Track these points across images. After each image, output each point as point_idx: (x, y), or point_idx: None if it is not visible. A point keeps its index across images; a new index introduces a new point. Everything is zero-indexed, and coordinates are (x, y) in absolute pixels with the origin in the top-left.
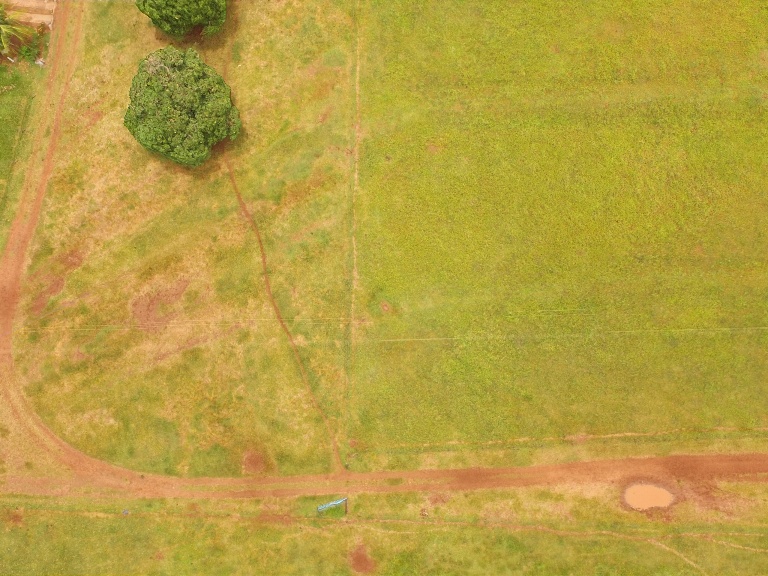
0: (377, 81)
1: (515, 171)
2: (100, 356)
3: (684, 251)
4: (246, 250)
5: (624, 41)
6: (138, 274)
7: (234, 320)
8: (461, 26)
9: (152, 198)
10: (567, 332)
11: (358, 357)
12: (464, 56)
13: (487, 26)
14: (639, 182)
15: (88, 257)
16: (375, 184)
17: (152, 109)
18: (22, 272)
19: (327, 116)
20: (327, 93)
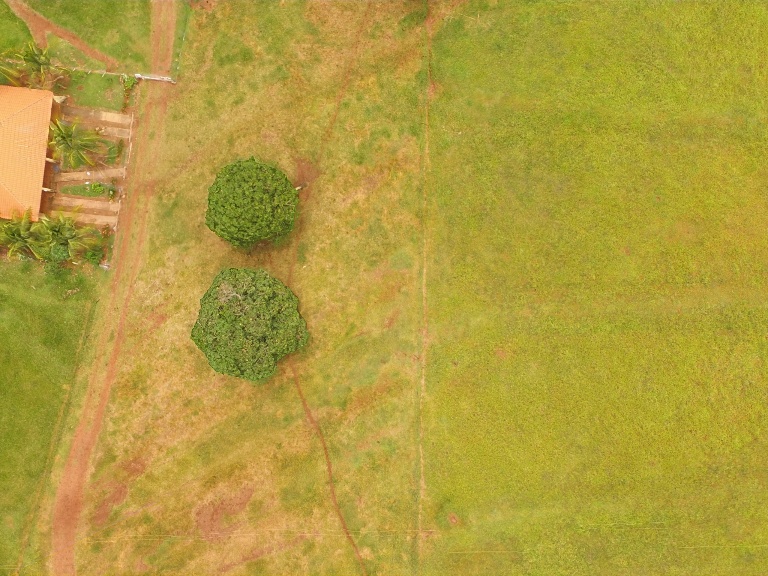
0: (444, 283)
1: (585, 378)
2: (163, 567)
3: (760, 462)
4: (311, 458)
5: (696, 243)
6: (202, 482)
7: (299, 530)
8: (529, 227)
9: (216, 403)
10: (640, 547)
11: (425, 571)
12: (533, 259)
13: (556, 227)
14: (713, 391)
15: (151, 464)
16: (442, 390)
17: (224, 340)
18: (85, 480)
19: (394, 321)
20: (393, 295)
